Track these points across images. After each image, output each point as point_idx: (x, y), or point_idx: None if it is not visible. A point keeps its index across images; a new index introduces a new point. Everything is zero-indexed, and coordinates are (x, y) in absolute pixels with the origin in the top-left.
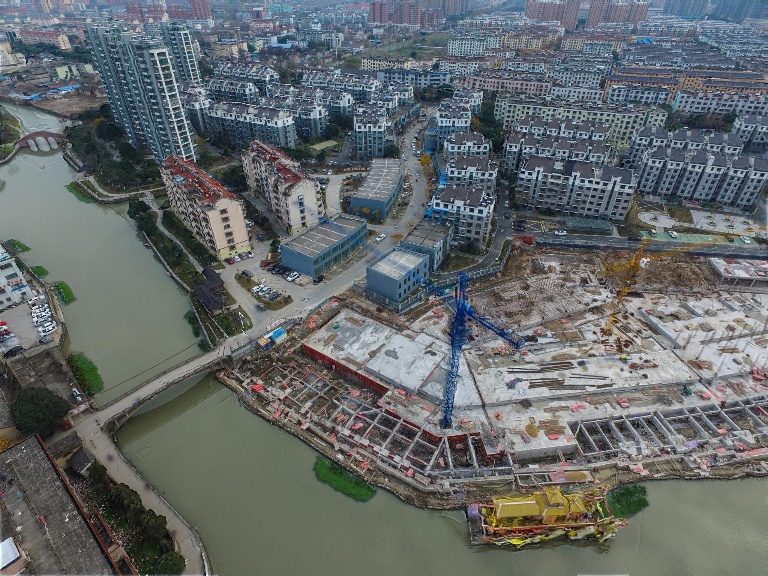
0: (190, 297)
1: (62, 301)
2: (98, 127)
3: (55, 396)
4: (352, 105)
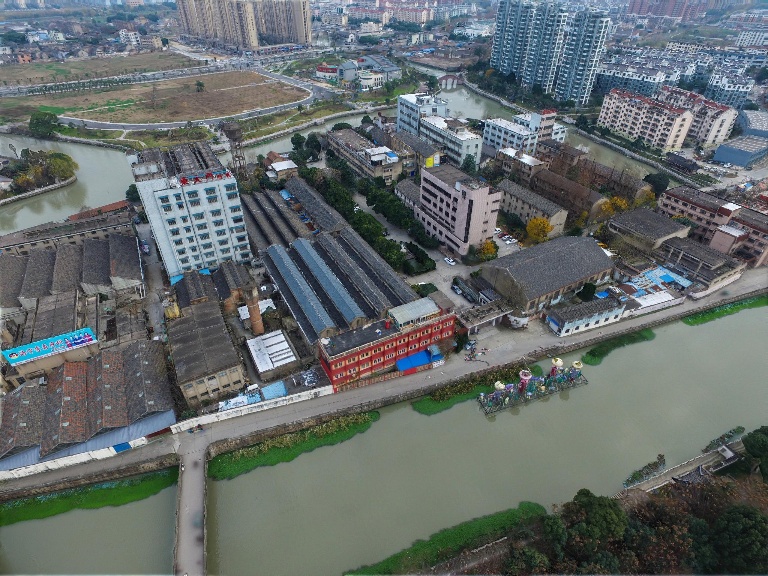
0: (663, 166)
1: None
2: (500, 74)
3: None
4: (692, 75)
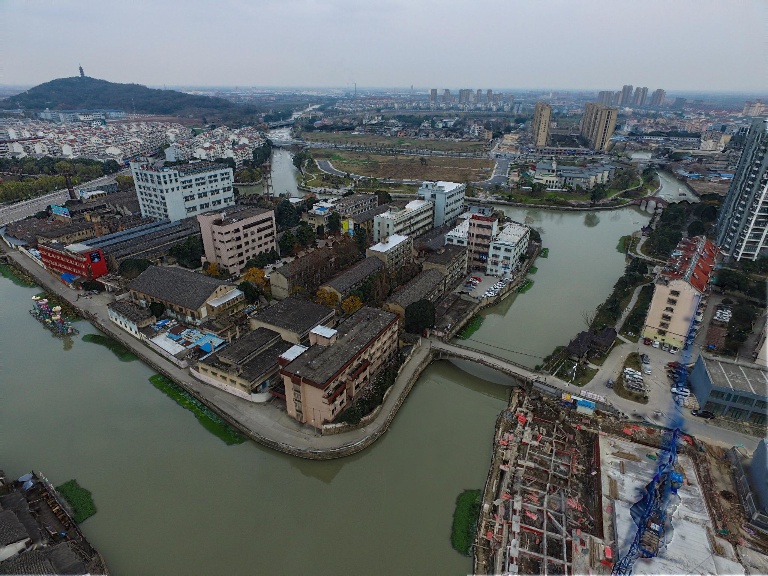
0: None
1: (518, 290)
2: (700, 205)
3: (431, 312)
4: None
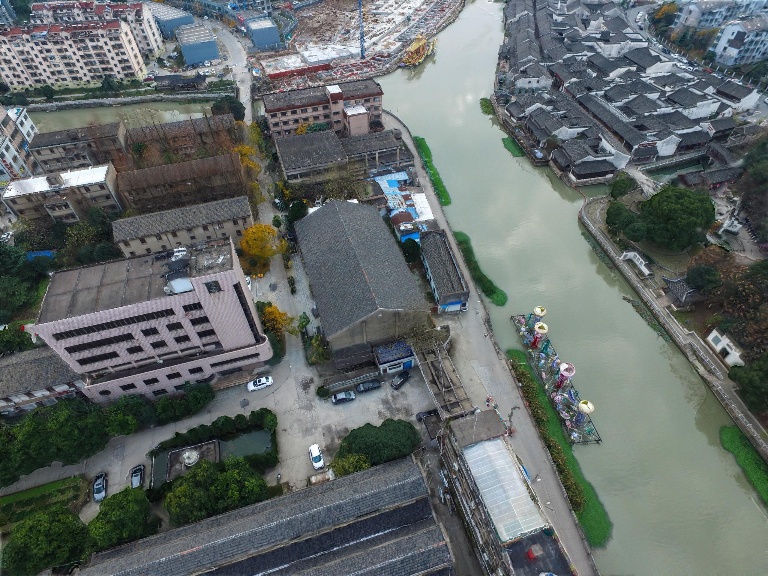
0: (169, 94)
1: None
2: None
3: None
4: None
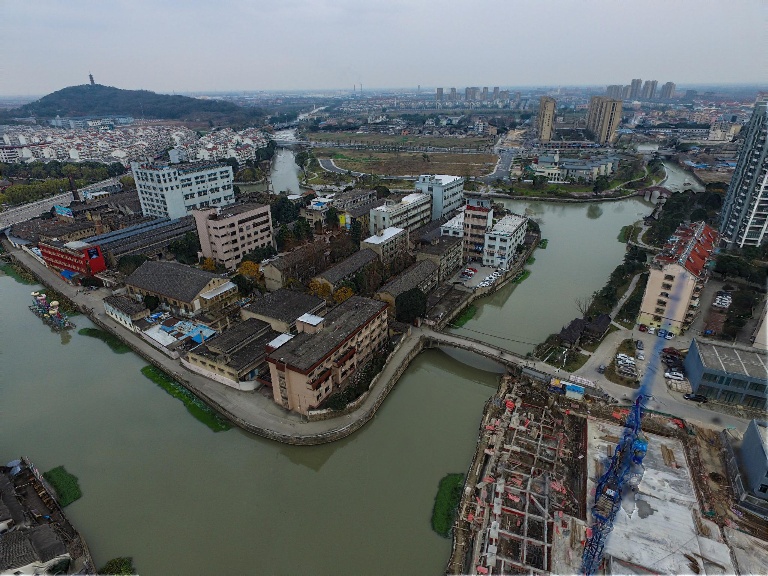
0: None
1: (514, 280)
2: (704, 194)
3: (421, 301)
4: None
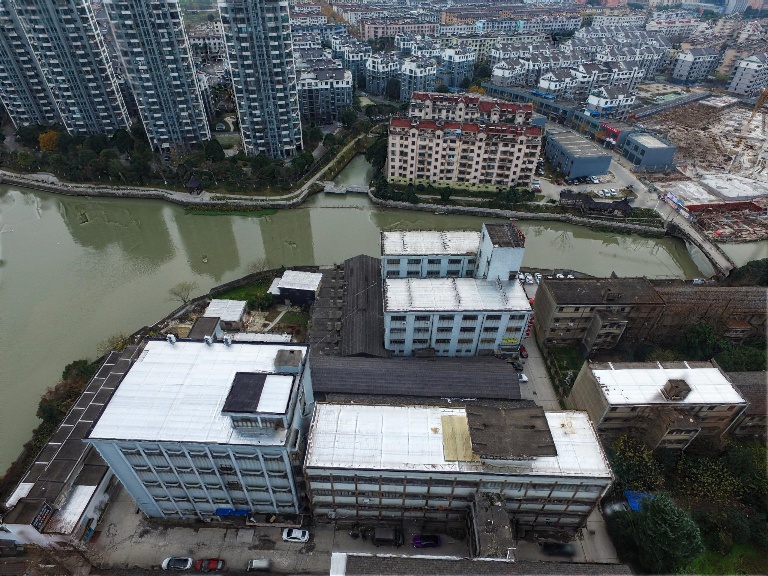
0: (581, 217)
1: None
2: (93, 139)
3: None
4: None
